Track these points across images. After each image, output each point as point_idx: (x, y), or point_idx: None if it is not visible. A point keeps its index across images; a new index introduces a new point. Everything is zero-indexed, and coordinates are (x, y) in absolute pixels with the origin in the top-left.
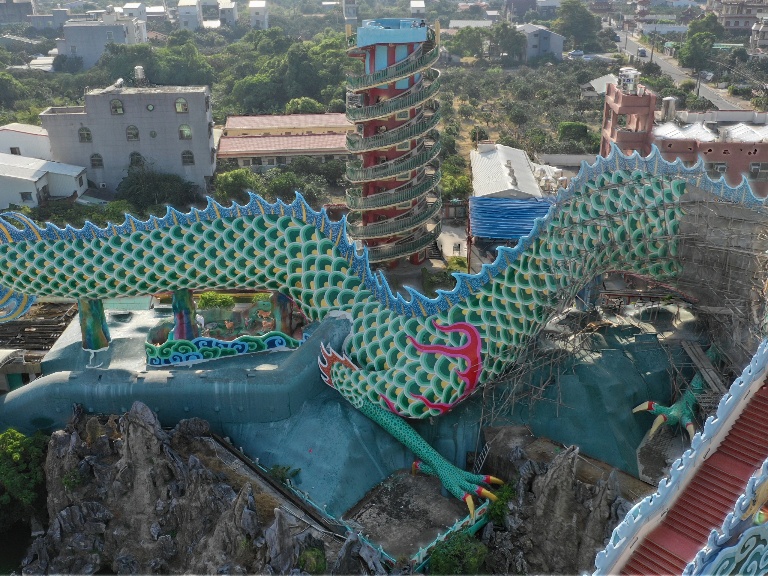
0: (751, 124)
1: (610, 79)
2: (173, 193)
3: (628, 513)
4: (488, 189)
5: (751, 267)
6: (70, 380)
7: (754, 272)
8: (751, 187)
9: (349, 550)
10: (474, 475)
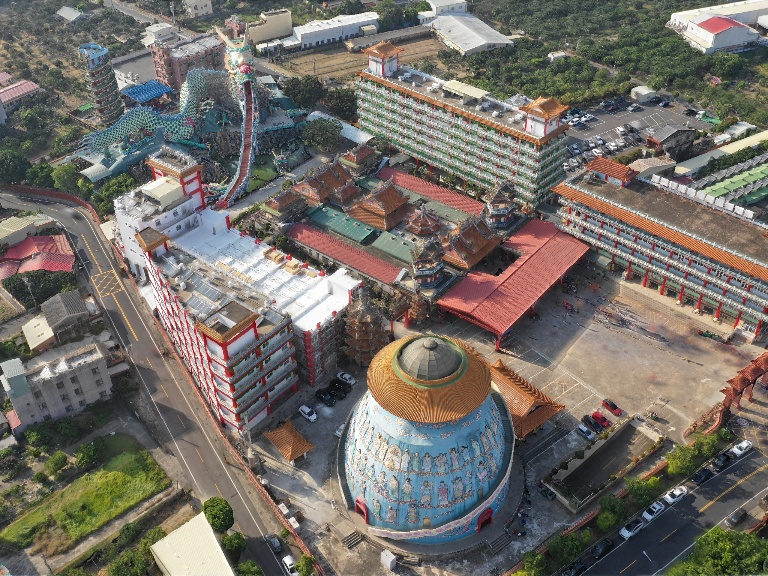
0: (187, 43)
1: (68, 10)
2: (5, 129)
3: (242, 126)
4: (119, 87)
5: (223, 87)
6: (124, 160)
7: (224, 87)
8: (202, 64)
9: (201, 158)
10: (204, 144)
